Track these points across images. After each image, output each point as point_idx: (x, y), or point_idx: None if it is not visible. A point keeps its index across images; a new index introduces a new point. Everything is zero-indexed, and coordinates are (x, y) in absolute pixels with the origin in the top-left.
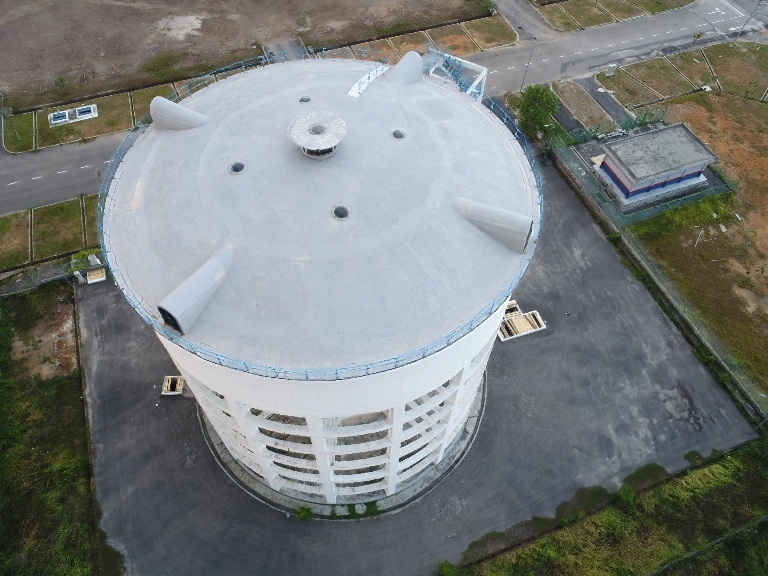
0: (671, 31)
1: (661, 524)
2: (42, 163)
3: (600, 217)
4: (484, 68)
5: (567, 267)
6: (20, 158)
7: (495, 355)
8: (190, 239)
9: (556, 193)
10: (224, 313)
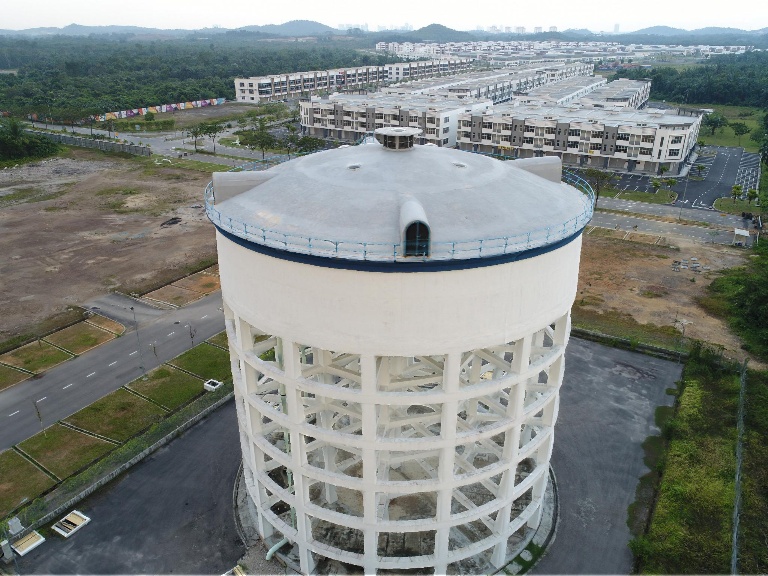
0: None
1: (704, 436)
2: None
3: None
4: None
5: None
6: None
7: None
8: (368, 205)
9: None
10: (448, 231)
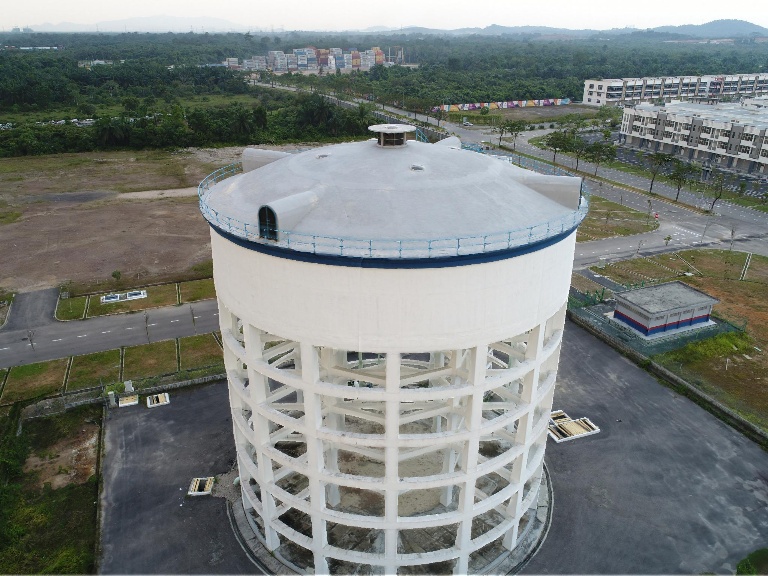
0: (644, 244)
1: None
2: (89, 327)
3: (626, 352)
4: None
5: (606, 386)
6: (68, 324)
7: (553, 454)
8: (284, 189)
9: (578, 337)
10: (317, 224)
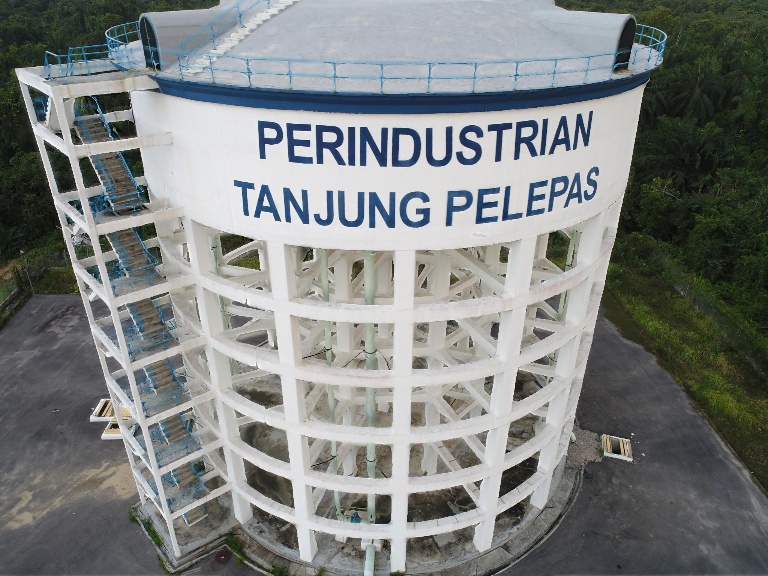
0: None
1: None
2: None
3: None
4: (21, 69)
5: None
6: None
7: None
8: None
9: None
10: None
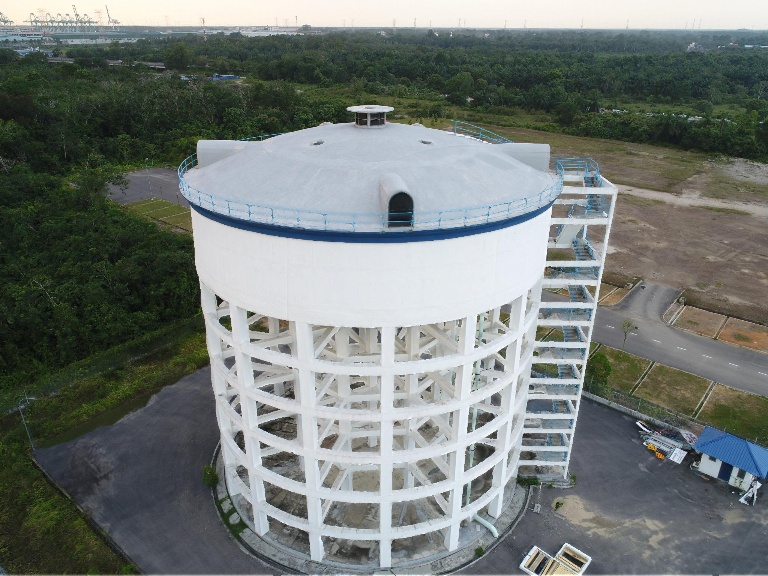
0: None
1: None
2: None
3: None
4: (614, 187)
5: None
6: None
7: (495, 568)
8: None
9: None
10: None
